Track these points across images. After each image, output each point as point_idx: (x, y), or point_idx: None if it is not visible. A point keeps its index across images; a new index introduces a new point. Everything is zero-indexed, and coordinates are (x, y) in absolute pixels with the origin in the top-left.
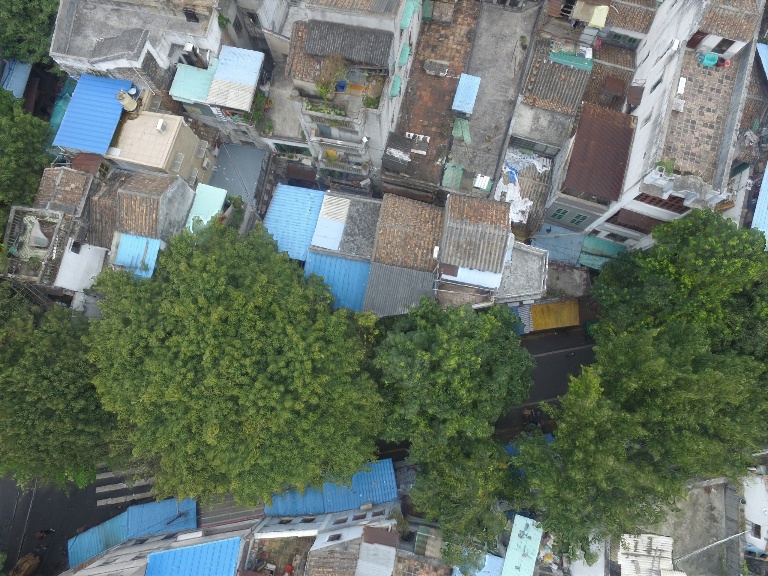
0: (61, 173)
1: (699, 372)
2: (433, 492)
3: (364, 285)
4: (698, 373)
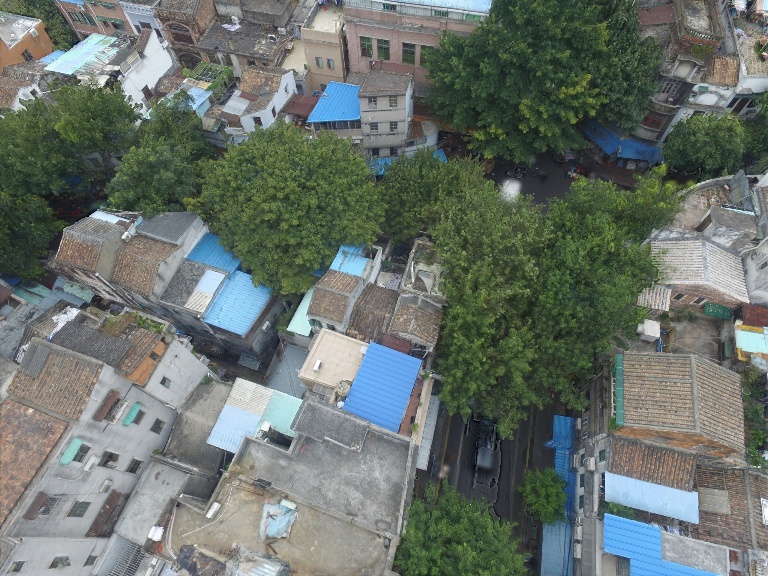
0: (410, 329)
1: (5, 142)
2: (189, 124)
3: (198, 248)
4: (6, 142)
